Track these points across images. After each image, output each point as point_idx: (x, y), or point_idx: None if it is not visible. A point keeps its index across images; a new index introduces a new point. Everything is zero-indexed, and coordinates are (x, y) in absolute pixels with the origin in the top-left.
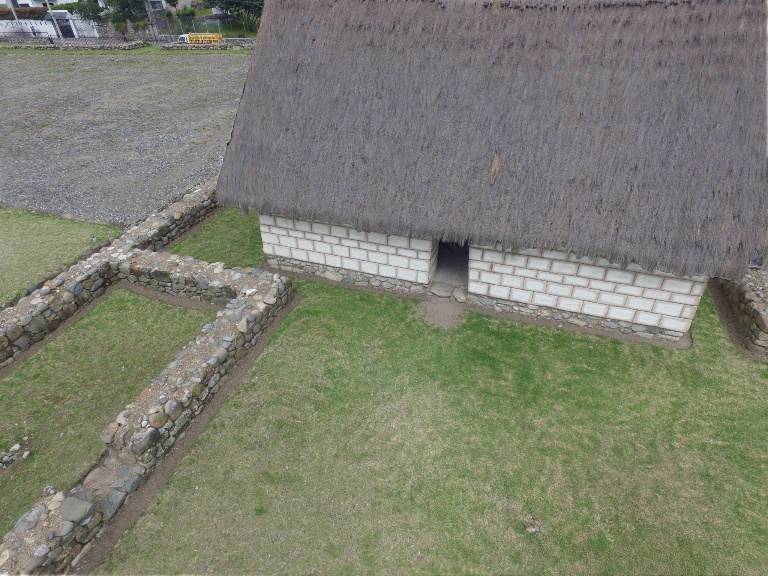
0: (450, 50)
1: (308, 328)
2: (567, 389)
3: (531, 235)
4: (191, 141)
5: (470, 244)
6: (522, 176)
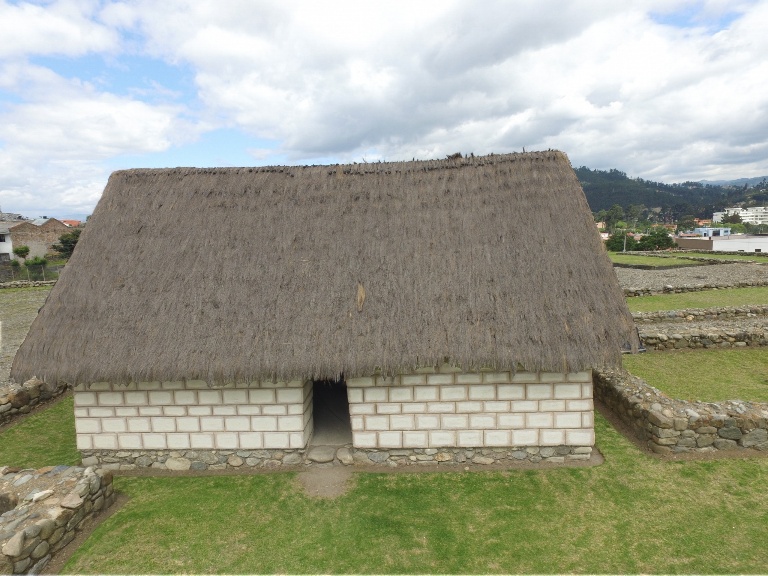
0: (302, 205)
1: (132, 536)
2: (496, 539)
3: (411, 355)
4: (5, 356)
5: (347, 378)
6: (389, 300)
